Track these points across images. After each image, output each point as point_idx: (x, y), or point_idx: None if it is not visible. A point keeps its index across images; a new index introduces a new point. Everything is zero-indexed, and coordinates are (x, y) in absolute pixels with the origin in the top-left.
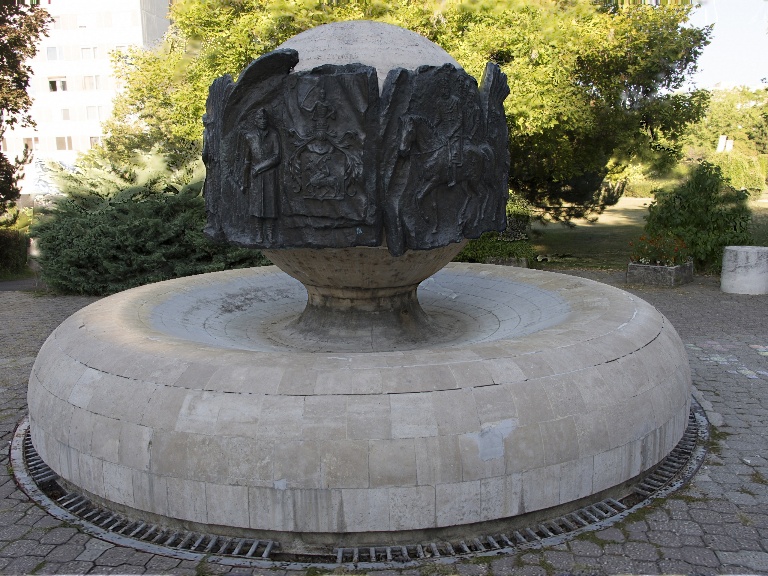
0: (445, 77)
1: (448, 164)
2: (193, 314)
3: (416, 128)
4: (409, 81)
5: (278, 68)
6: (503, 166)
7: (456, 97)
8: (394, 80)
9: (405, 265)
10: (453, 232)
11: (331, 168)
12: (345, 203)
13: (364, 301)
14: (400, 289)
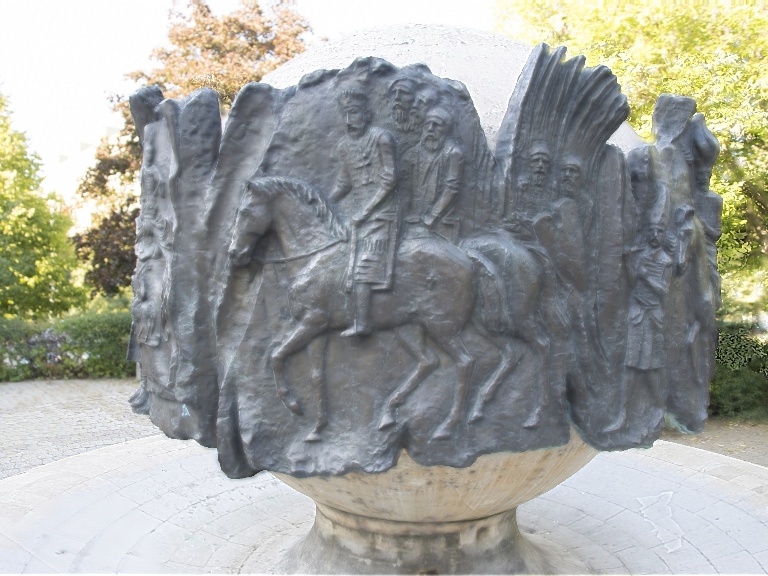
0: (352, 88)
1: (345, 284)
2: (225, 477)
3: (269, 205)
4: (274, 108)
5: (148, 120)
6: (610, 290)
7: (378, 130)
8: (230, 109)
9: (360, 487)
10: (360, 445)
11: (150, 286)
12: (161, 353)
13: (349, 531)
14: (414, 526)
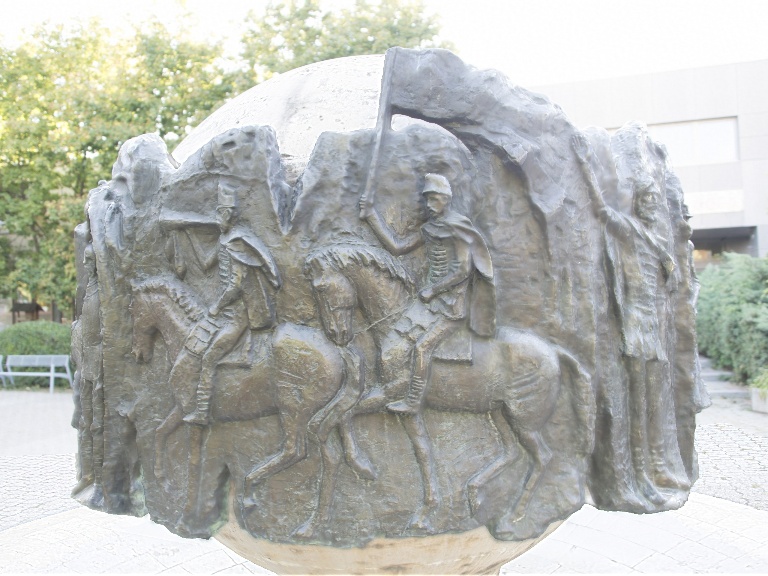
0: None
1: None
2: None
3: None
4: None
5: None
6: None
7: None
8: None
9: None
10: None
11: None
12: None
13: None
14: None
